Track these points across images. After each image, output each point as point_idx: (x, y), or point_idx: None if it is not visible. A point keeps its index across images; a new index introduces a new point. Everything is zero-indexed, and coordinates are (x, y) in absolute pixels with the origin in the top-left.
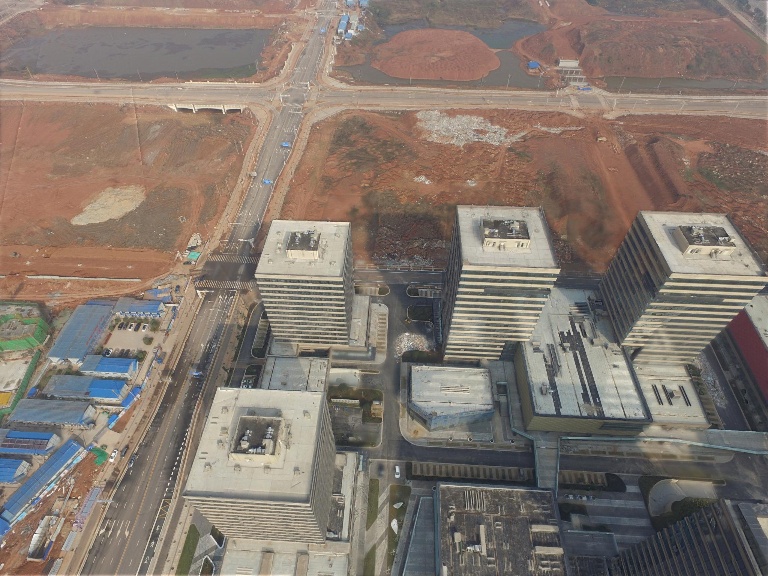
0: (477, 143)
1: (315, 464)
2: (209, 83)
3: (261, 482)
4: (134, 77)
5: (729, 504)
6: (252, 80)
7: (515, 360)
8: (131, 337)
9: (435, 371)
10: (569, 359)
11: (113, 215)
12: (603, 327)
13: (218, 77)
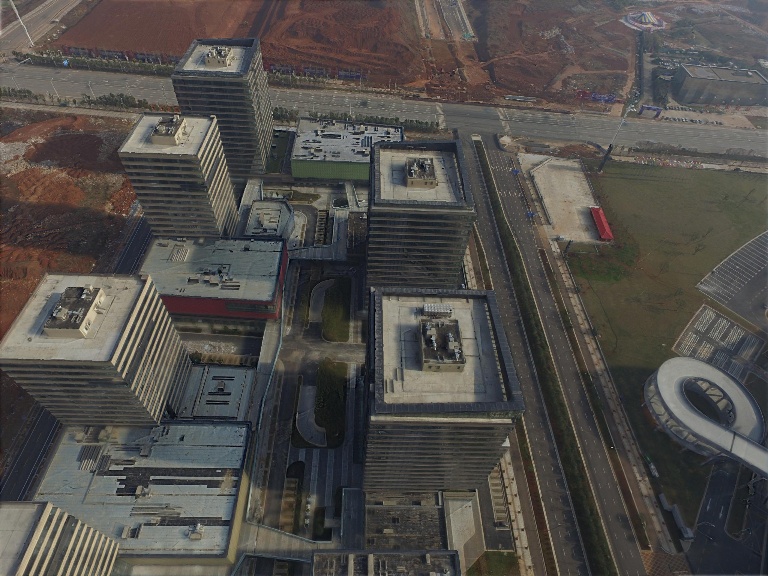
0: None
1: None
2: None
3: None
4: None
5: (374, 418)
6: None
7: (136, 564)
8: None
9: None
10: (159, 491)
11: None
12: (126, 436)
13: None
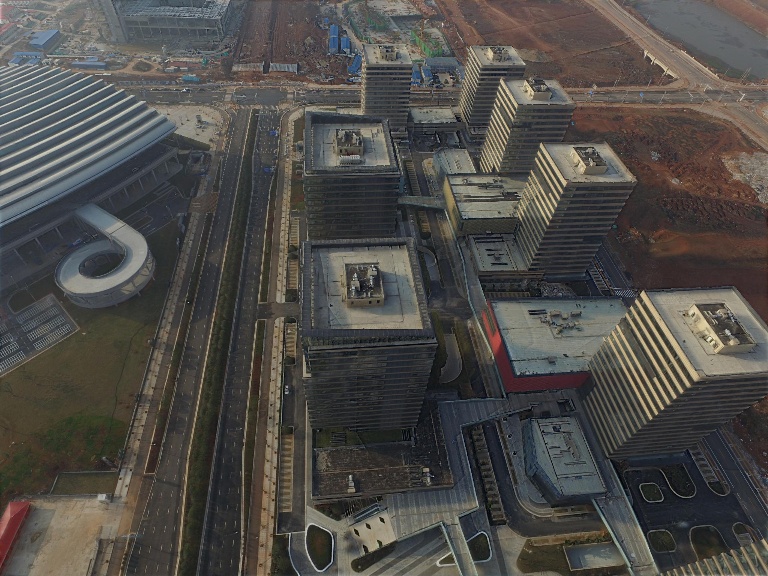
0: (747, 186)
1: (381, 64)
2: (692, 59)
3: (371, 57)
4: (669, 36)
5: None
6: (726, 79)
7: None
8: (446, 78)
9: (467, 158)
10: (495, 193)
11: (523, 57)
12: None
13: (711, 64)
